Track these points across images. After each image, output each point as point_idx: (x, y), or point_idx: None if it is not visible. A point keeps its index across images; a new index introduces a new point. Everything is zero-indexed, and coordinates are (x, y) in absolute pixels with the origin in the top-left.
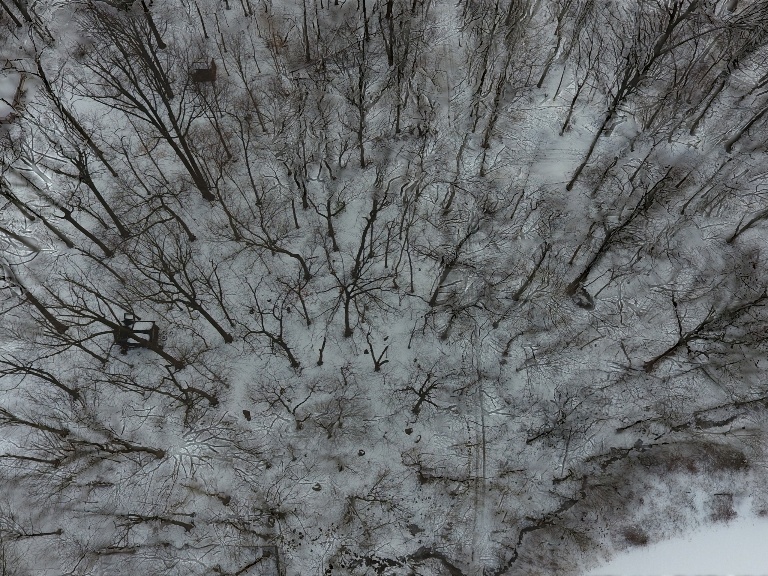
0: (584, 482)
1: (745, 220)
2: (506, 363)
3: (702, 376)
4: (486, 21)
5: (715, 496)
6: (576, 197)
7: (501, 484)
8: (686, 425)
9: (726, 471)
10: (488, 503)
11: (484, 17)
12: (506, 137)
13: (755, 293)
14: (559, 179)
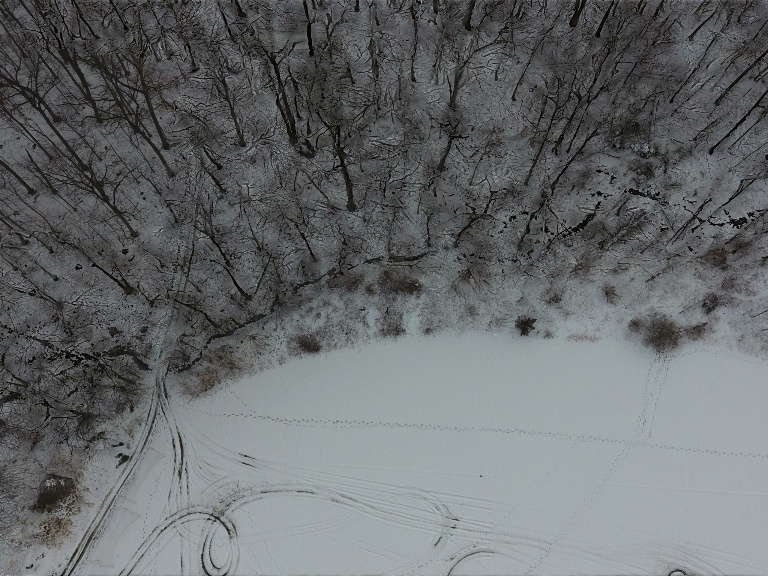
0: (275, 300)
1: (451, 79)
2: (223, 198)
3: (403, 218)
4: None
5: (386, 314)
6: (317, 62)
7: (198, 297)
8: (379, 258)
9: (400, 294)
10: (183, 312)
11: None
12: (262, 8)
13: (468, 151)
14: (304, 46)
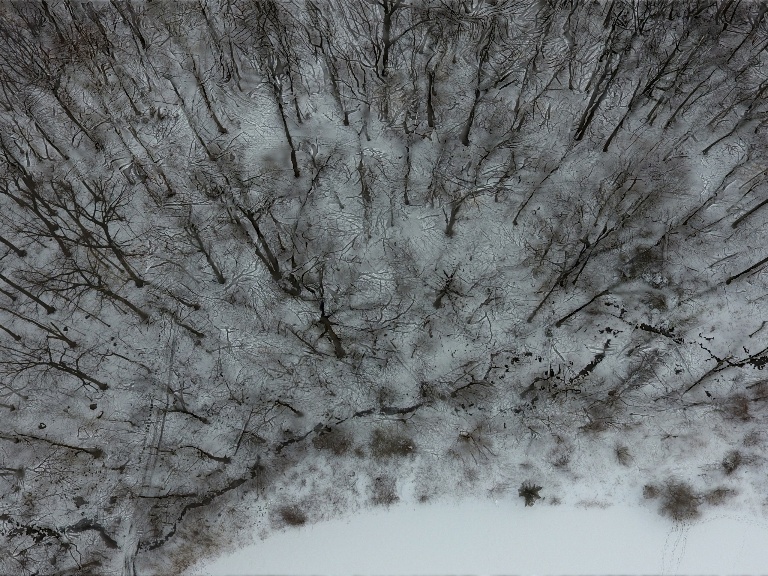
0: (256, 462)
1: (447, 211)
2: None
3: (395, 364)
4: (237, 7)
5: (377, 480)
6: (303, 184)
7: (172, 461)
8: (370, 411)
9: (393, 456)
10: (155, 479)
11: (235, 2)
12: (244, 122)
13: (466, 284)
14: (289, 166)
